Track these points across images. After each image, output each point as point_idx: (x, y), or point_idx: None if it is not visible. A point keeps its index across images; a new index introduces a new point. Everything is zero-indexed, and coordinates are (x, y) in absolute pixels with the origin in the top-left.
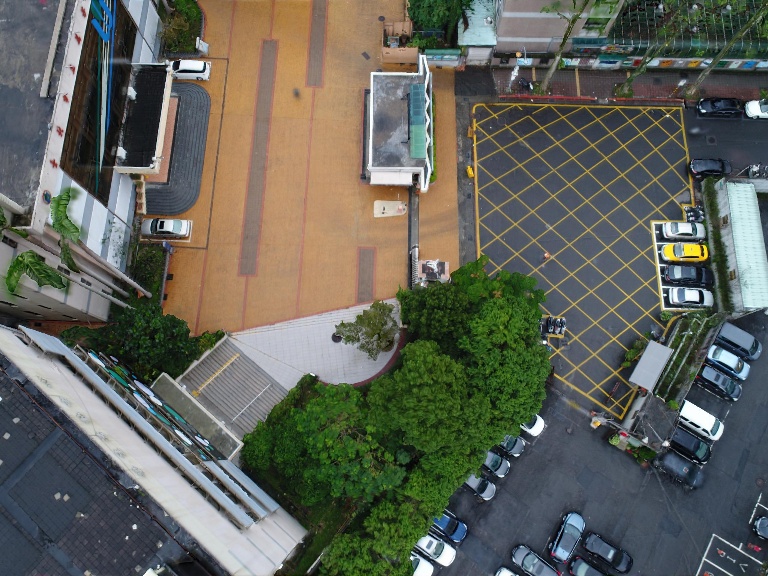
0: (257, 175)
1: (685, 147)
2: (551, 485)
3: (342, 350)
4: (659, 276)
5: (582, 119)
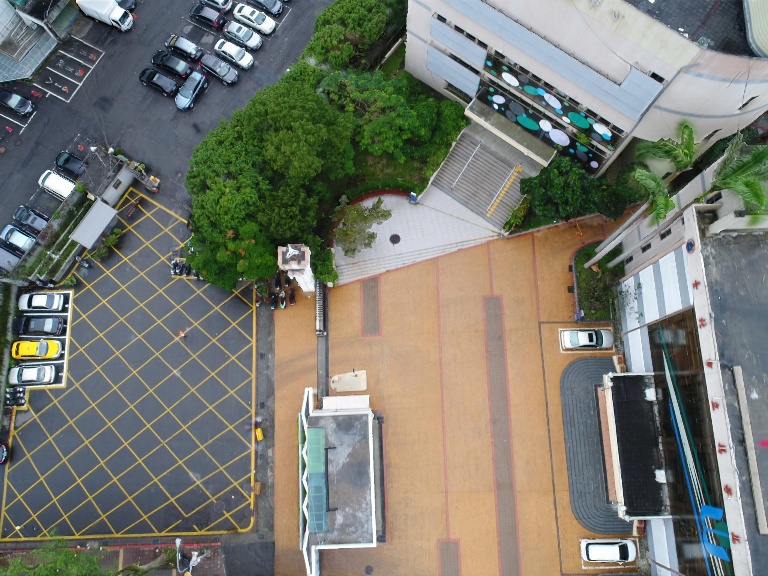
0: (500, 412)
1: (7, 484)
2: (201, 130)
3: (389, 228)
4: (69, 326)
5: (122, 516)
